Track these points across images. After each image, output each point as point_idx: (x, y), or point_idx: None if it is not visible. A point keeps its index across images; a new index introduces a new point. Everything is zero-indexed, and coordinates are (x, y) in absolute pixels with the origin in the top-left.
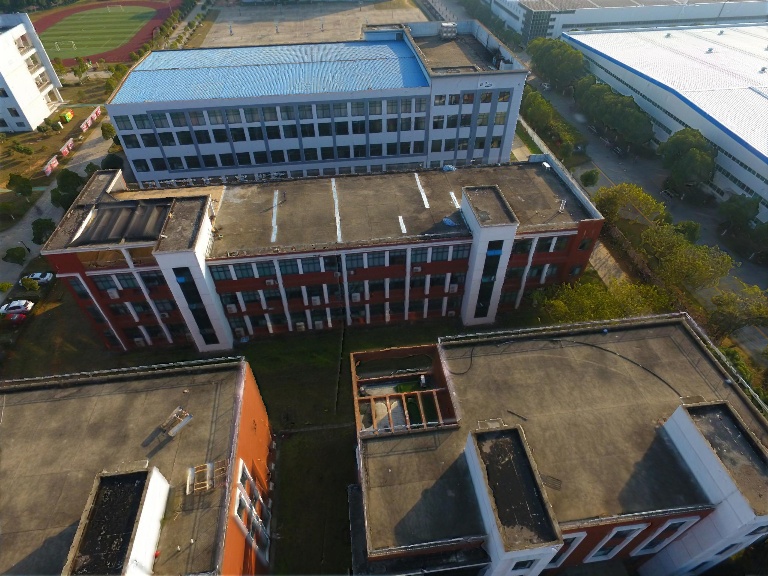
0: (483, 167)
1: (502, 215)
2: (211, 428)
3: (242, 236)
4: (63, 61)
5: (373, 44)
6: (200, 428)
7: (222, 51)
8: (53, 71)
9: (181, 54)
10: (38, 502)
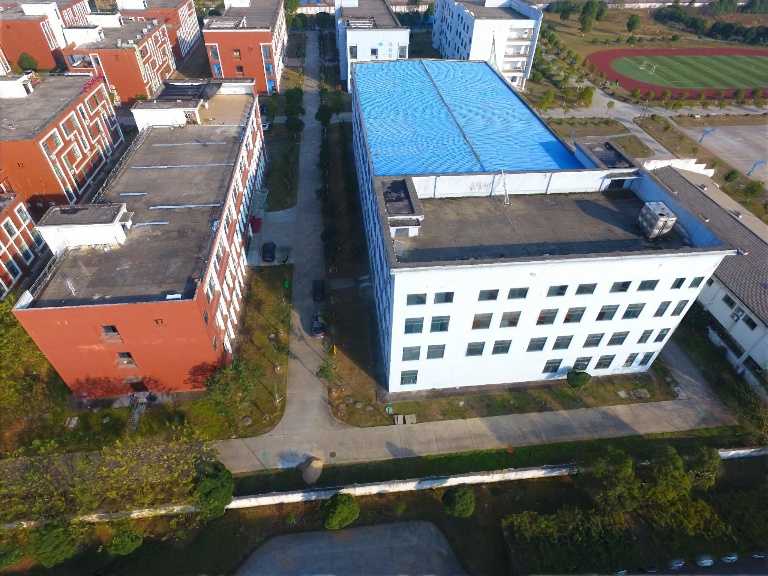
0: (209, 250)
1: (60, 221)
2: (0, 136)
3: (168, 135)
4: (614, 75)
5: (558, 158)
6: (4, 134)
7: (495, 85)
8: (530, 64)
9: (479, 71)
10: (7, 111)
